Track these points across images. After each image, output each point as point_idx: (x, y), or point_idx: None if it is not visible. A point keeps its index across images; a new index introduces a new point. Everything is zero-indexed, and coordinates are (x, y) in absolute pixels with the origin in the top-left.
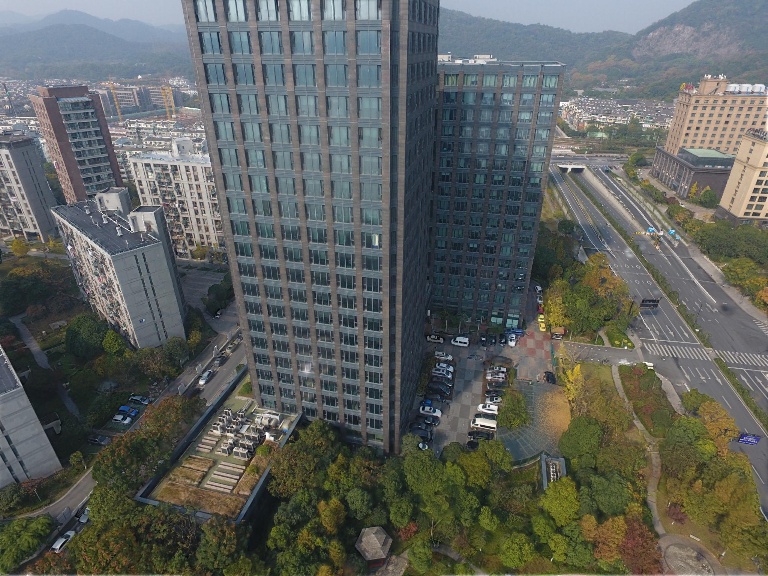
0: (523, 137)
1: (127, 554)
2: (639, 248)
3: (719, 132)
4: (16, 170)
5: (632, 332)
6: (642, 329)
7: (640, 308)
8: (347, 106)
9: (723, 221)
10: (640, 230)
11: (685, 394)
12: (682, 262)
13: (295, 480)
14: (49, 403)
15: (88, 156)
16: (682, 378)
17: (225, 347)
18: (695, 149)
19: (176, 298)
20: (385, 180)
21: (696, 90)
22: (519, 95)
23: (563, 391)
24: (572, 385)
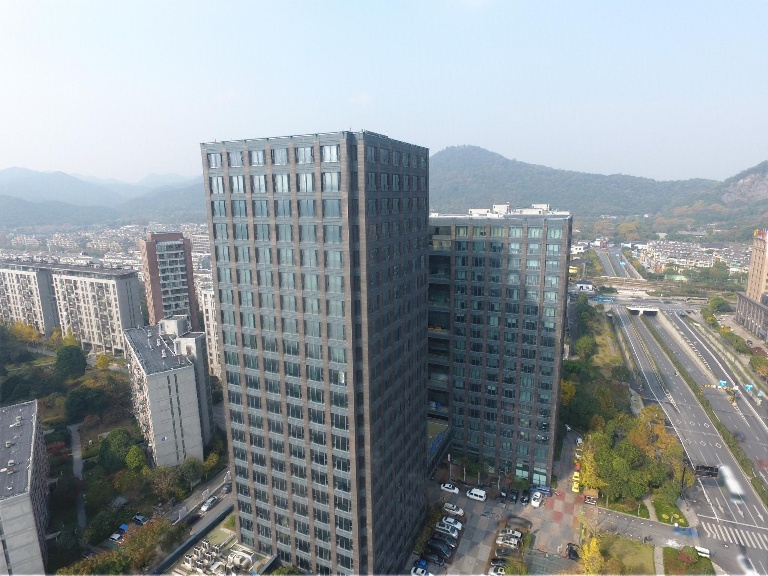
0: (533, 283)
1: None
2: (710, 403)
3: None
4: (118, 297)
5: (687, 505)
6: (701, 503)
7: (695, 476)
8: (317, 258)
9: None
10: (715, 382)
11: None
12: (764, 424)
13: None
14: (65, 512)
15: (172, 287)
16: (749, 575)
17: None
18: None
19: None
20: (348, 322)
21: None
22: (525, 245)
23: (582, 571)
24: (590, 564)
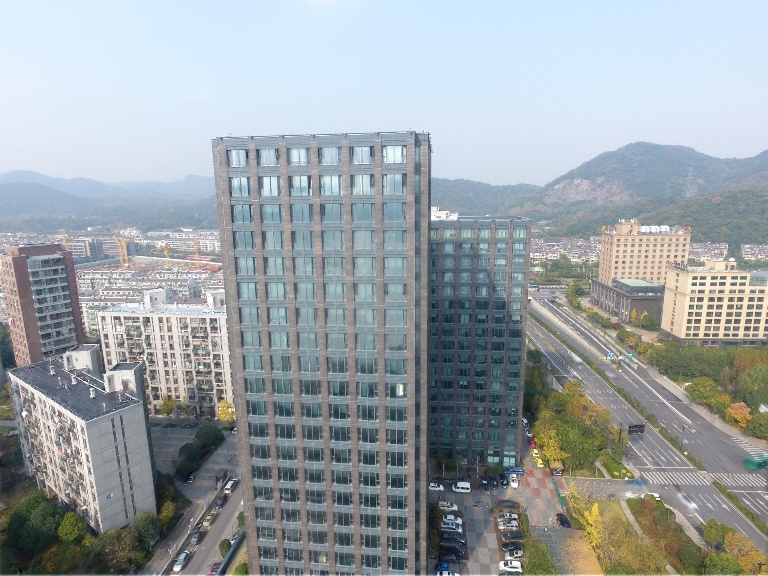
0: (501, 280)
1: None
2: (604, 373)
3: (642, 265)
4: None
5: (627, 461)
6: (635, 456)
7: (628, 435)
8: (373, 265)
9: (670, 343)
10: (599, 355)
11: (704, 526)
12: (647, 384)
13: None
14: None
15: (51, 312)
16: (690, 507)
17: (201, 519)
18: (626, 280)
19: (150, 464)
20: (410, 331)
21: (615, 231)
22: (494, 245)
23: (583, 536)
24: (592, 528)
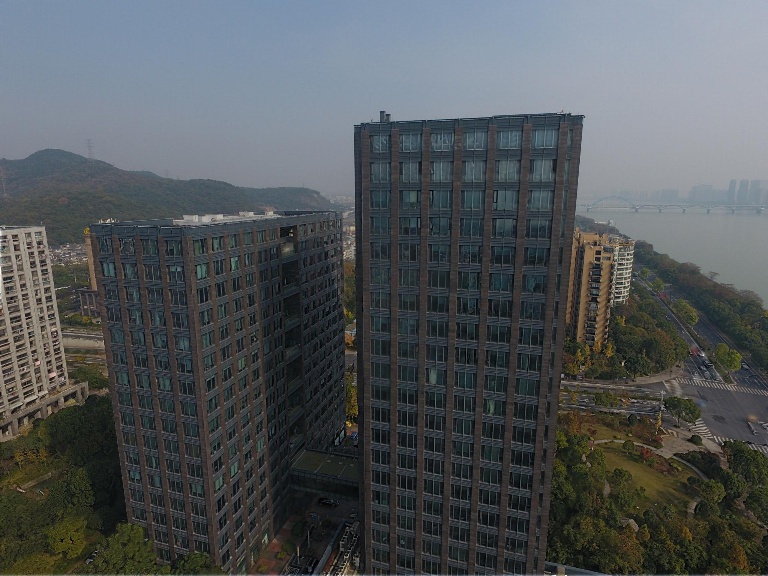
0: None
1: None
2: None
3: None
4: None
5: None
6: None
7: None
8: None
9: None
10: None
11: None
12: None
13: None
14: None
15: None
16: None
17: None
18: None
19: None
20: None
21: None
22: None
23: None
24: None
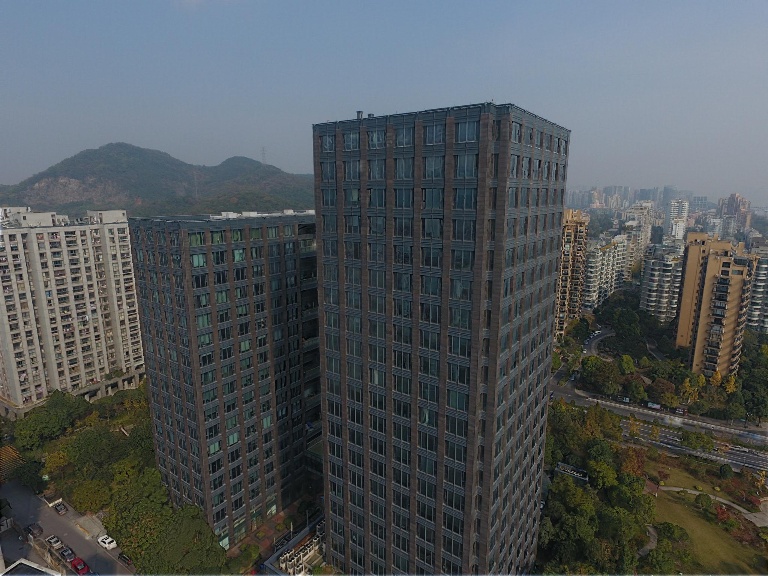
0: None
1: None
2: None
3: None
4: None
5: None
6: None
7: None
8: None
9: None
10: None
11: None
12: None
13: None
14: None
15: None
16: None
17: None
18: None
19: None
20: None
21: None
22: None
23: None
24: None
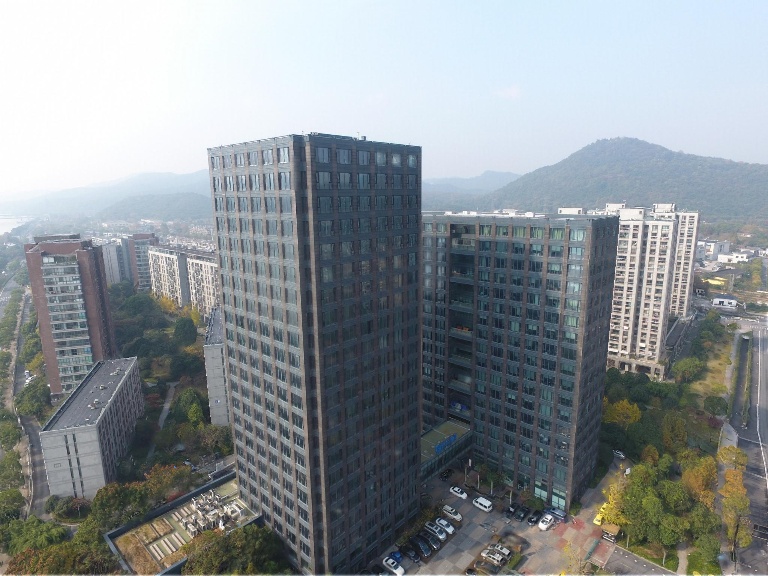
0: (555, 288)
1: (54, 571)
2: None
3: None
4: None
5: (734, 569)
6: (758, 571)
7: (752, 536)
8: None
9: None
10: None
11: None
12: None
13: (201, 570)
14: (141, 449)
15: None
16: None
17: None
18: None
19: None
20: (299, 310)
21: None
22: (547, 247)
23: None
24: None
